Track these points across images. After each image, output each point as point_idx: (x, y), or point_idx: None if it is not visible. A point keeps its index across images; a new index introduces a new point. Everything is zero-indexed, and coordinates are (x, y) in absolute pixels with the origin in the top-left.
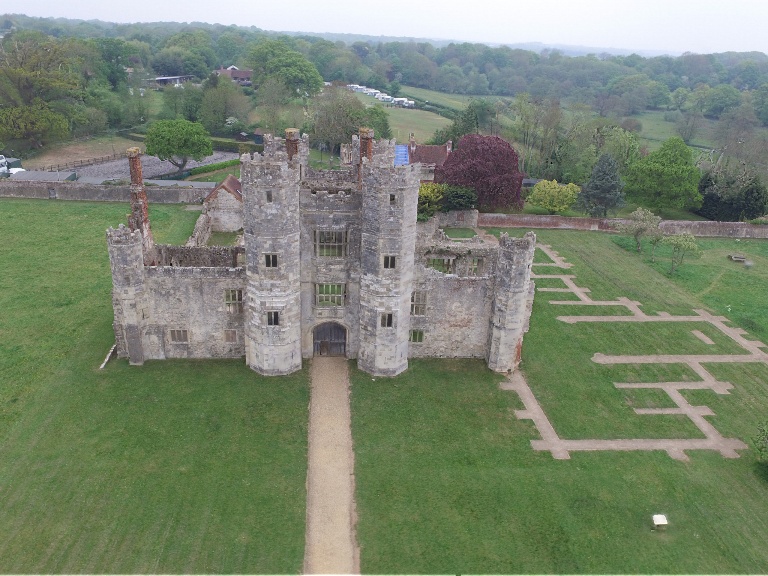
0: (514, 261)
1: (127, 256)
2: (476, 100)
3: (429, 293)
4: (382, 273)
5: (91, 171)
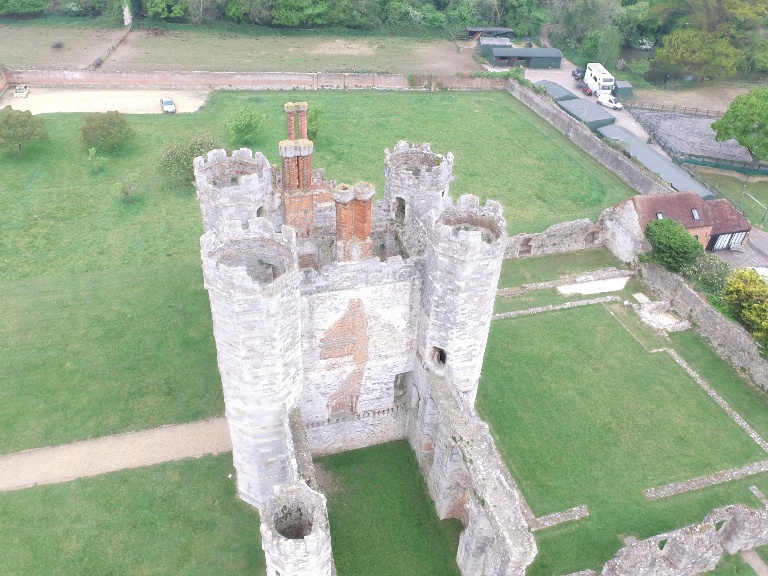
0: None
1: None
2: None
3: (288, 459)
4: None
5: (686, 124)
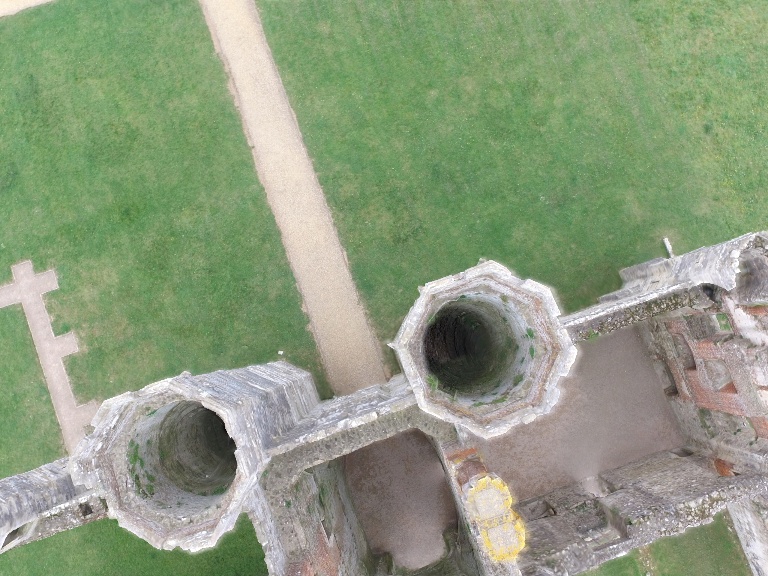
0: None
1: None
2: None
3: None
4: None
5: None
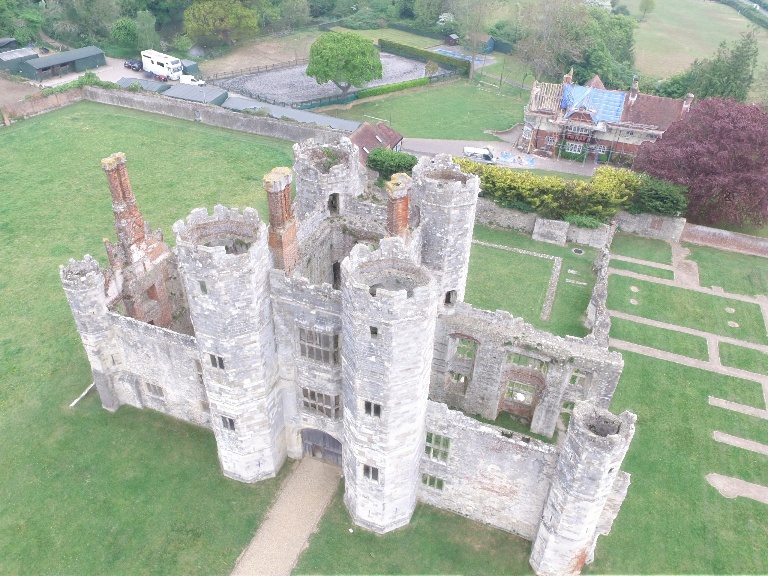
0: (582, 459)
1: (79, 302)
2: (761, 27)
3: (452, 441)
4: (361, 419)
5: (262, 81)
